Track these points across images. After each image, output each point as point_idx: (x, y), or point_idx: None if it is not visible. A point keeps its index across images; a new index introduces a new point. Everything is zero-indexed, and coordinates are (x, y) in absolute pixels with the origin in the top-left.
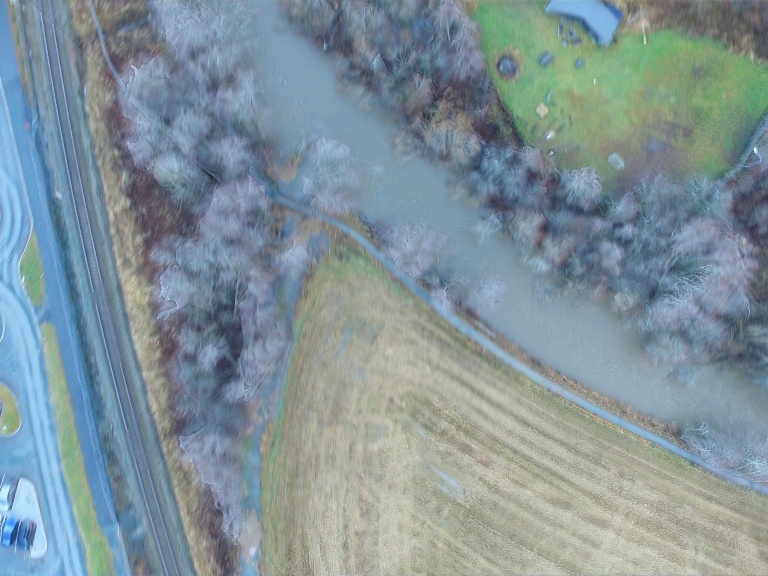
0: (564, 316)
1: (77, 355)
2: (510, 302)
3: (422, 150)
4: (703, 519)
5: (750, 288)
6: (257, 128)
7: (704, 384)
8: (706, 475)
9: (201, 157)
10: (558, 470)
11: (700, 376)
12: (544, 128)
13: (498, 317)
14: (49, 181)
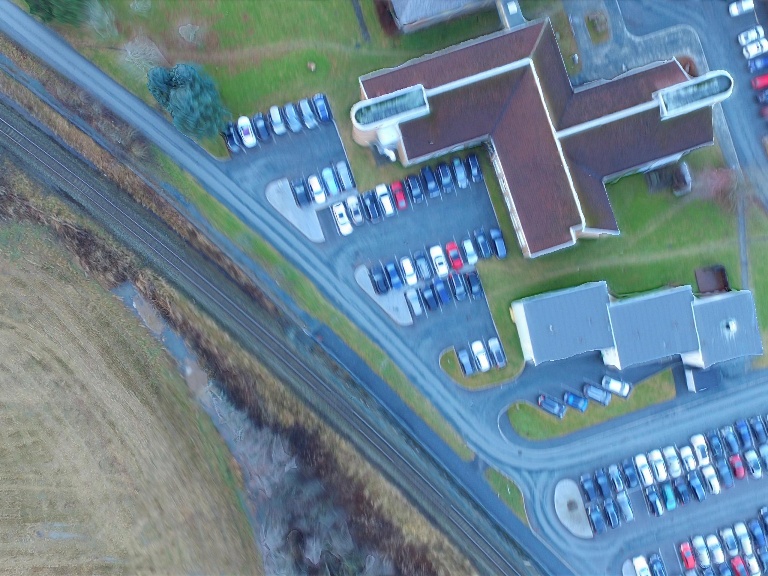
0: None
1: None
2: None
3: None
4: None
5: None
6: None
7: None
8: None
9: None
10: None
11: None
12: None
13: None
14: (542, 571)
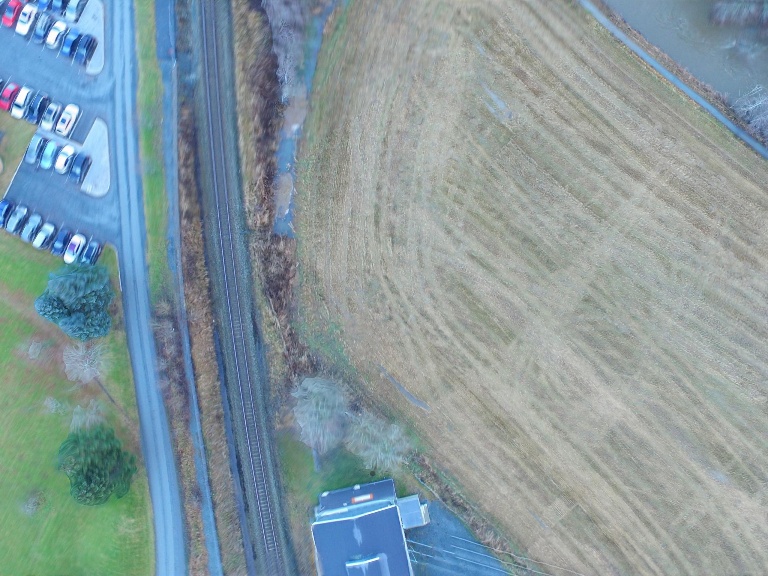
0: None
1: None
2: None
3: None
4: (735, 193)
5: None
6: None
7: (764, 59)
8: (747, 150)
9: None
10: (605, 115)
11: (761, 52)
12: None
13: None
14: None
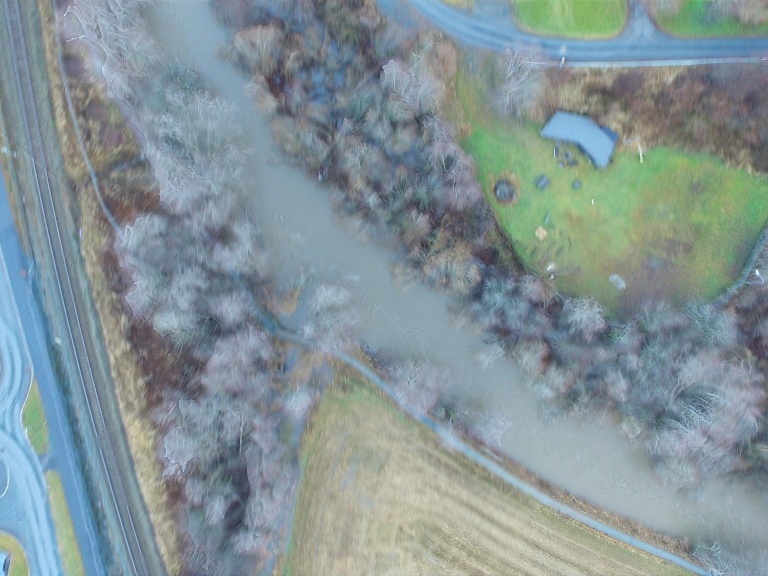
0: (571, 437)
1: (83, 503)
2: (516, 428)
3: (422, 279)
4: None
5: (757, 404)
6: (255, 270)
7: (714, 500)
8: None
9: (200, 310)
10: None
11: (710, 491)
12: (543, 251)
13: (505, 442)
14: (48, 328)
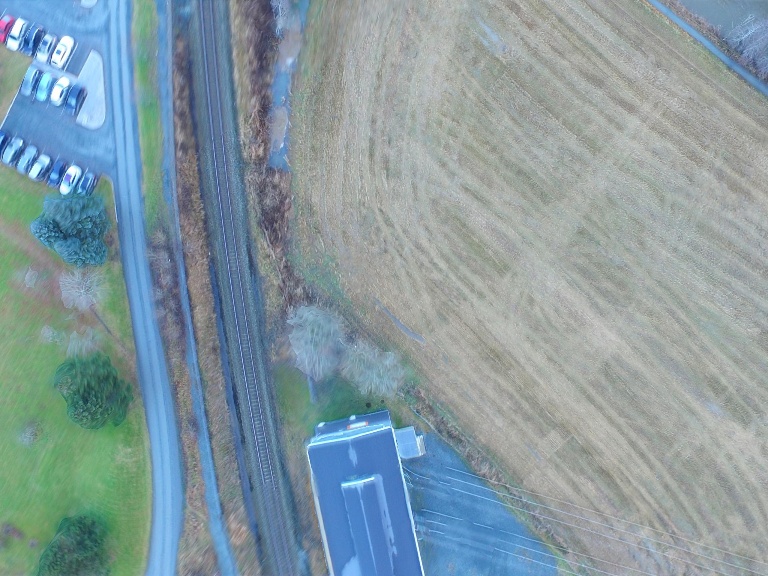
0: None
1: None
2: None
3: None
4: (728, 125)
5: None
6: None
7: None
8: (740, 82)
9: None
10: (598, 47)
11: None
12: None
13: None
14: None
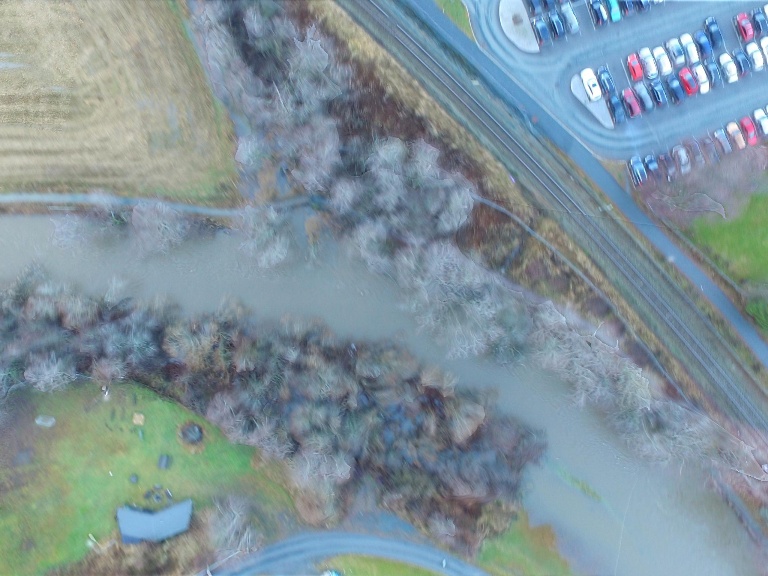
0: (3, 265)
1: None
2: None
3: (216, 317)
4: None
5: None
6: None
7: None
8: None
9: None
10: None
11: None
12: (128, 406)
13: None
14: (490, 88)
